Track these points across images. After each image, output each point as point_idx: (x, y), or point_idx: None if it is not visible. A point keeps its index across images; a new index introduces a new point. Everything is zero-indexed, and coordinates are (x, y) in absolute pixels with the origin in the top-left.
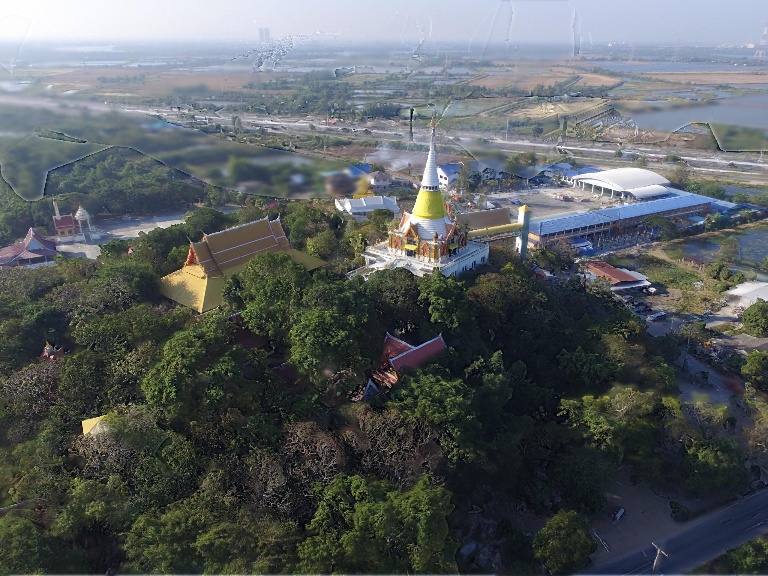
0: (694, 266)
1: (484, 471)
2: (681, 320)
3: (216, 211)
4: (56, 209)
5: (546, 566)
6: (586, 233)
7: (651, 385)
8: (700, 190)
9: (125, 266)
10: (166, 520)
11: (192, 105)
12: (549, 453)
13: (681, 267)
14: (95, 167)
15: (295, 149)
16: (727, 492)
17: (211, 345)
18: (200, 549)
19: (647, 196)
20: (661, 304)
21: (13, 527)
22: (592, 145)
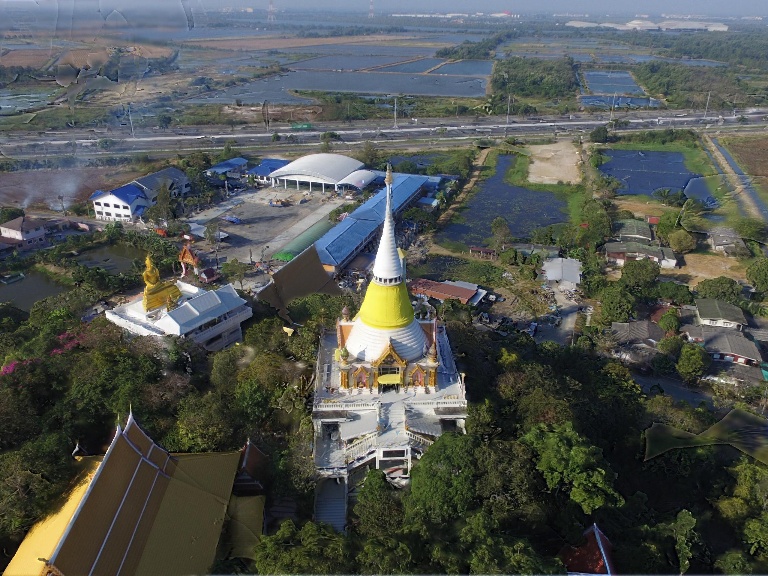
0: (483, 256)
1: None
2: (547, 325)
3: None
4: None
5: None
6: (363, 245)
7: None
8: (393, 167)
9: None
10: None
11: None
12: None
13: (473, 260)
14: None
15: None
16: None
17: None
18: None
19: (365, 185)
20: (512, 312)
21: None
22: (232, 130)
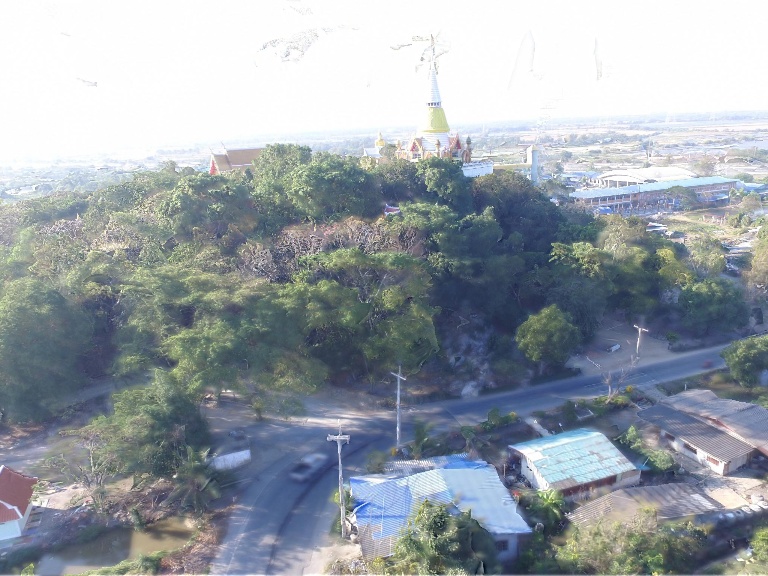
0: (715, 221)
1: (470, 284)
2: None
3: None
4: None
5: (529, 354)
6: (606, 205)
7: (647, 247)
8: None
9: (153, 173)
10: (161, 269)
11: None
12: (540, 289)
13: (702, 223)
14: None
15: None
16: (725, 325)
17: (217, 182)
18: (188, 281)
19: None
20: None
21: (28, 282)
22: (622, 165)
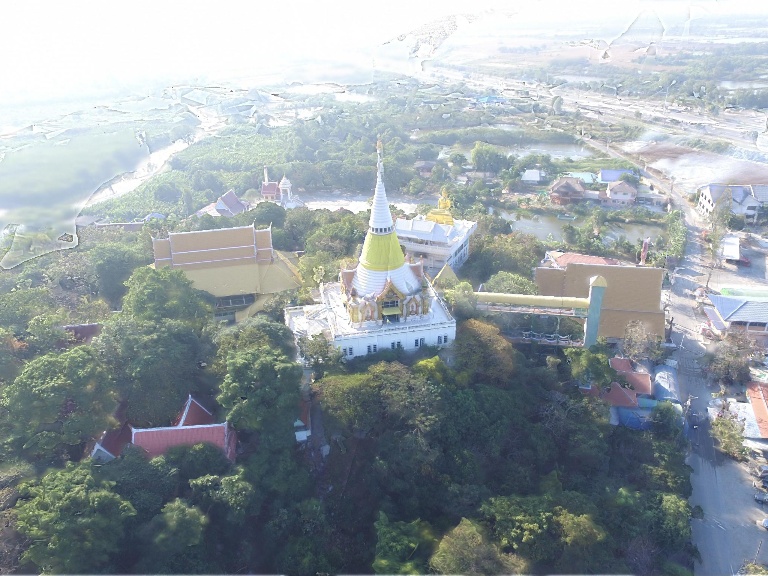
0: None
1: None
2: None
3: (277, 206)
4: (266, 176)
5: None
6: None
7: None
8: None
9: (106, 247)
10: None
11: (546, 80)
12: None
13: None
14: (361, 139)
15: (589, 139)
16: None
17: None
18: None
19: None
20: None
21: None
22: None
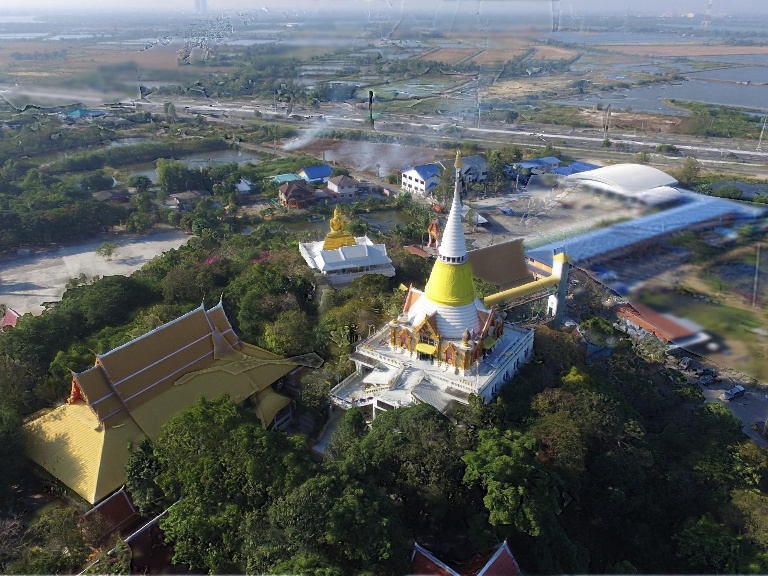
0: None
1: None
2: (763, 395)
3: (128, 278)
4: None
5: None
6: None
7: None
8: (712, 191)
9: None
10: None
11: None
12: None
13: None
14: None
15: (239, 143)
16: None
17: None
18: None
19: None
20: None
21: None
22: (572, 131)
